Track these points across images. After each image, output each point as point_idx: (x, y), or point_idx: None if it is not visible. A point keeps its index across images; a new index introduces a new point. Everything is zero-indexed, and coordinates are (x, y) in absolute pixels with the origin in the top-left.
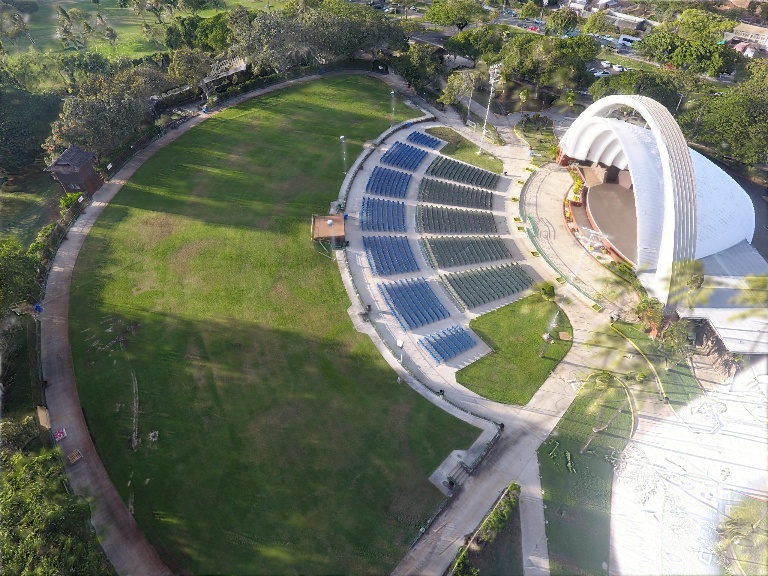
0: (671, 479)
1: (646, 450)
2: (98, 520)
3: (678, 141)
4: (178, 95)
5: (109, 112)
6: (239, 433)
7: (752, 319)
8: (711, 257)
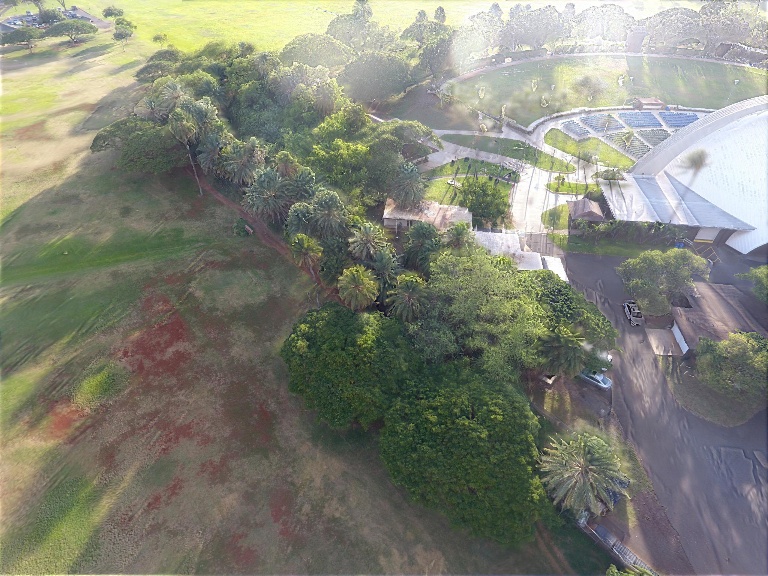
0: (517, 171)
1: (530, 169)
2: (479, 70)
3: (764, 101)
4: (763, 55)
5: (682, 24)
6: (511, 86)
7: (634, 194)
8: (706, 201)
